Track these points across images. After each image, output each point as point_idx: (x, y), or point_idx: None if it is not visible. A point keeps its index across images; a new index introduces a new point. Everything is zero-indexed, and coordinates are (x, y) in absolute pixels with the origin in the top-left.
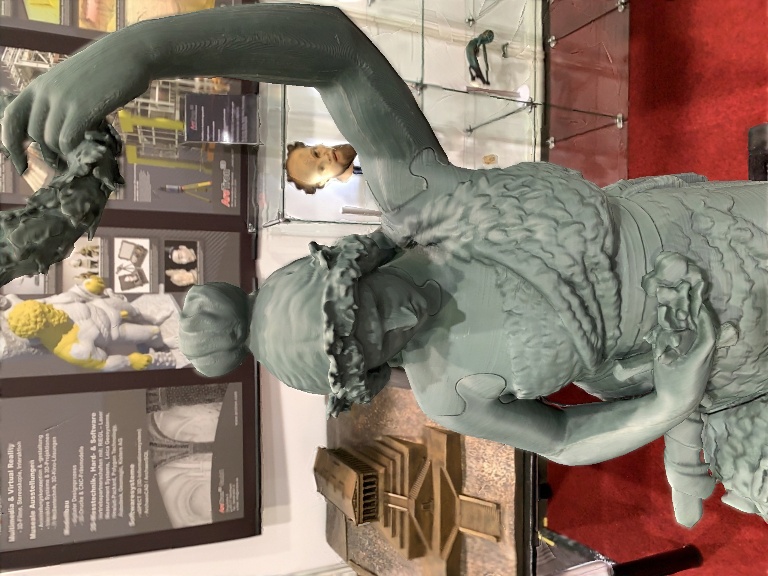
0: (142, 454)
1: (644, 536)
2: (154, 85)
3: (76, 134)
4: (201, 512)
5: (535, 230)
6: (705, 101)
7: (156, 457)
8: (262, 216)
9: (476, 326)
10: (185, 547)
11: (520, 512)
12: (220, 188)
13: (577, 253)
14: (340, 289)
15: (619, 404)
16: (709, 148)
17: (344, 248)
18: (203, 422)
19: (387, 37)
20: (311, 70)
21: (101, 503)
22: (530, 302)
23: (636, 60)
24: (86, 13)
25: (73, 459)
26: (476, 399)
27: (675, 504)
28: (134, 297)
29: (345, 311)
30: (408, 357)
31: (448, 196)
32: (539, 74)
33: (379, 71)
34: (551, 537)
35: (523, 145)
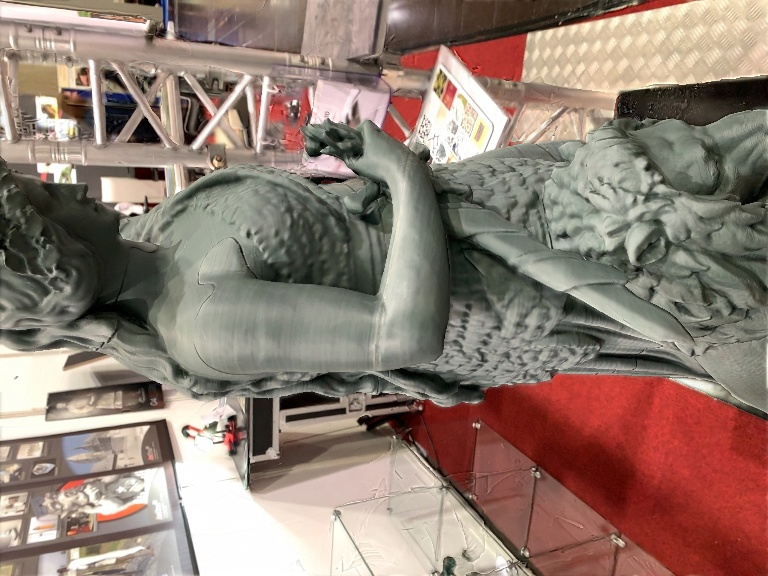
0: None
1: None
2: None
3: None
4: None
5: None
6: (641, 453)
7: None
8: None
9: (190, 234)
10: None
11: None
12: None
13: None
14: None
15: None
16: (683, 474)
17: None
18: None
19: None
20: None
21: None
22: (221, 193)
23: (579, 490)
24: None
25: None
26: (223, 277)
27: (613, 314)
28: None
29: None
30: (153, 314)
31: None
32: None
33: None
34: None
35: None
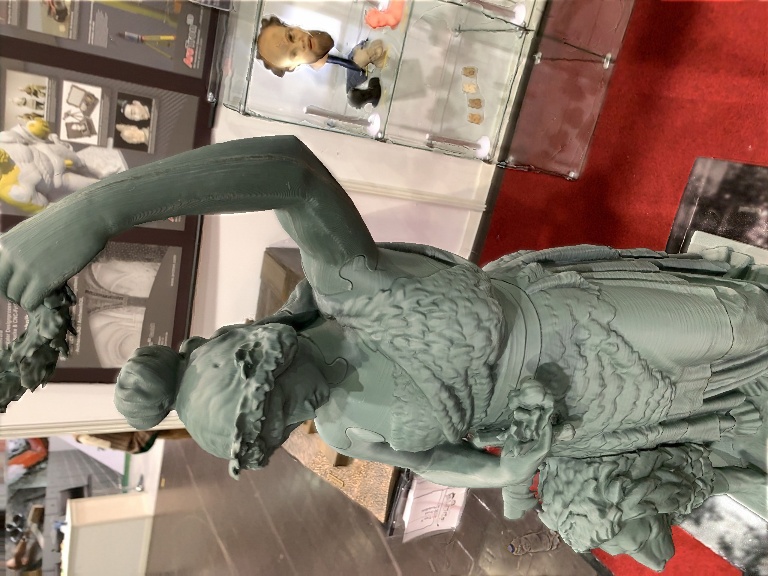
0: None
1: None
2: None
3: (36, 302)
4: None
5: (432, 346)
6: (689, 71)
7: (91, 304)
8: (225, 83)
9: (370, 398)
10: (111, 384)
11: None
12: (184, 45)
13: (462, 368)
14: (253, 403)
15: (474, 454)
16: (676, 121)
17: (265, 354)
18: (140, 279)
19: None
20: (260, 208)
21: None
22: (416, 395)
23: (643, 0)
24: None
25: None
26: (360, 442)
27: (505, 508)
28: (80, 147)
29: (254, 423)
30: None
31: (368, 299)
32: None
33: (325, 202)
34: None
35: (510, 53)
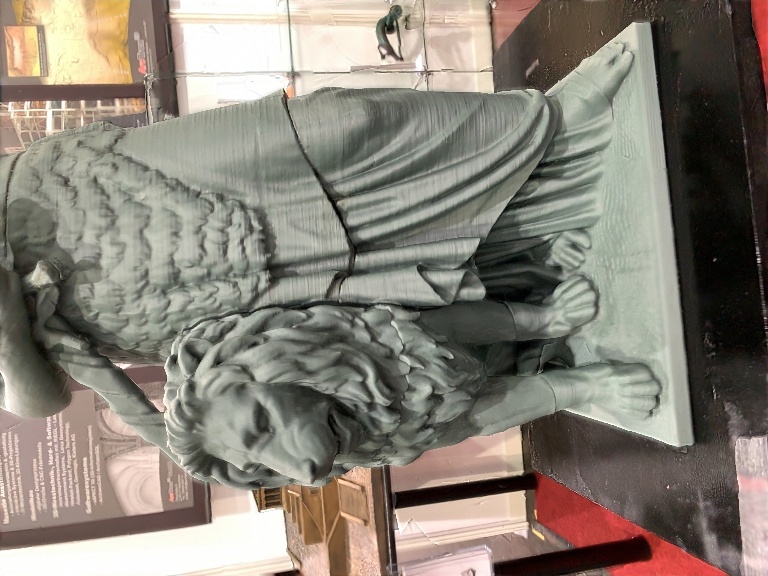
0: (93, 448)
1: (606, 527)
2: (79, 116)
3: None
4: (152, 501)
5: None
6: None
7: (106, 451)
8: None
9: None
10: (141, 533)
11: (380, 494)
12: None
13: None
14: None
15: None
16: None
17: None
18: None
19: (251, 33)
20: None
21: (60, 492)
22: None
23: None
24: (14, 63)
25: (34, 454)
26: None
27: None
28: None
29: None
30: None
31: None
32: (487, 39)
33: None
34: (541, 531)
35: None
